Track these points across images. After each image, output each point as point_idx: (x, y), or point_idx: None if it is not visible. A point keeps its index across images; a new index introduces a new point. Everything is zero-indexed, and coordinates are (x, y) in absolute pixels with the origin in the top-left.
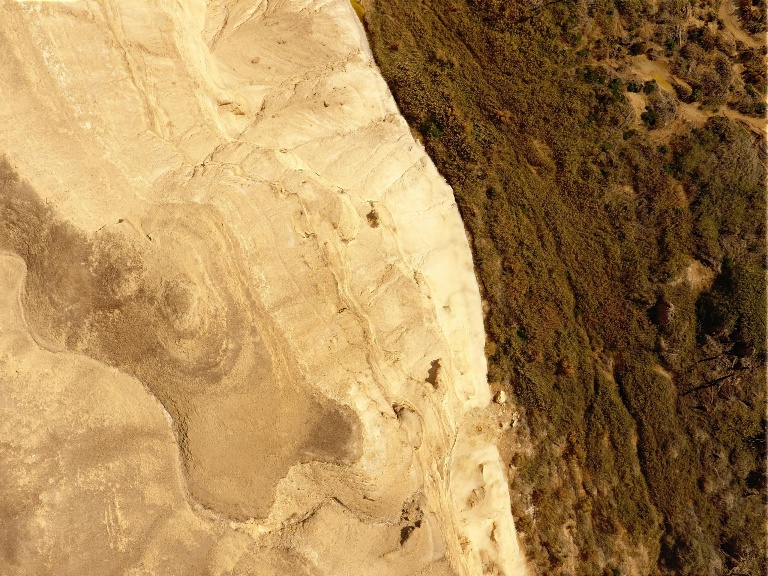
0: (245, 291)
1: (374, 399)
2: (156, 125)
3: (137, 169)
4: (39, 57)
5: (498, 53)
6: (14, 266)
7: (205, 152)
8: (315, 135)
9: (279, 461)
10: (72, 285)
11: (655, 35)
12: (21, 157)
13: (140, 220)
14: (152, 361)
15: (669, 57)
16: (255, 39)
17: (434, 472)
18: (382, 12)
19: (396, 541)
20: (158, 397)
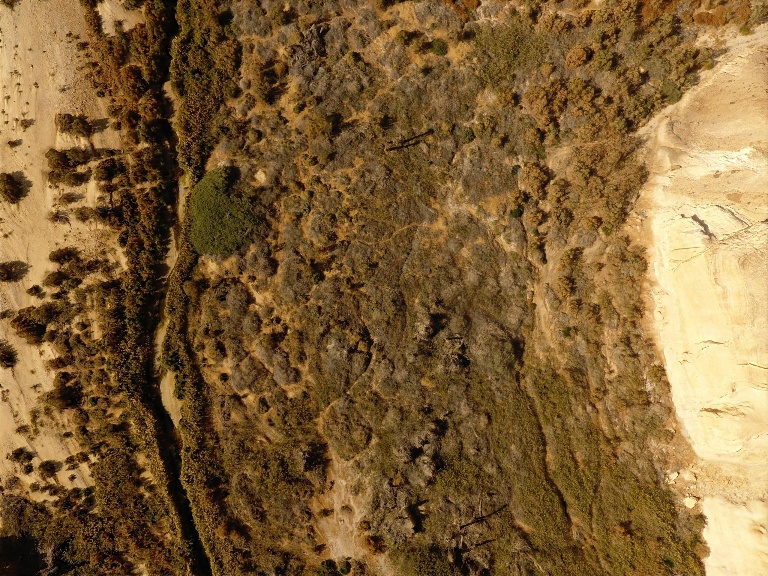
0: None
1: None
2: None
3: None
4: None
5: None
6: None
7: None
8: None
9: None
10: None
11: None
12: None
13: None
14: None
15: None
16: None
17: None
18: None
19: None
20: None
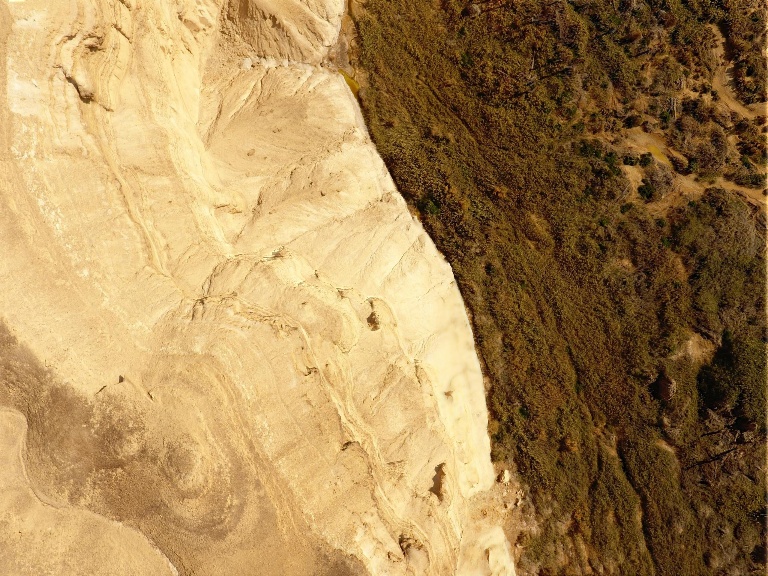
0: (248, 444)
1: (380, 540)
2: (154, 256)
3: (136, 314)
4: (34, 206)
5: (493, 128)
6: (14, 422)
7: (203, 275)
8: (313, 225)
9: None
10: (74, 446)
11: (650, 108)
12: (19, 318)
13: (141, 375)
14: (156, 518)
15: (664, 129)
16: (250, 131)
17: None
18: (376, 88)
19: None
20: (163, 551)
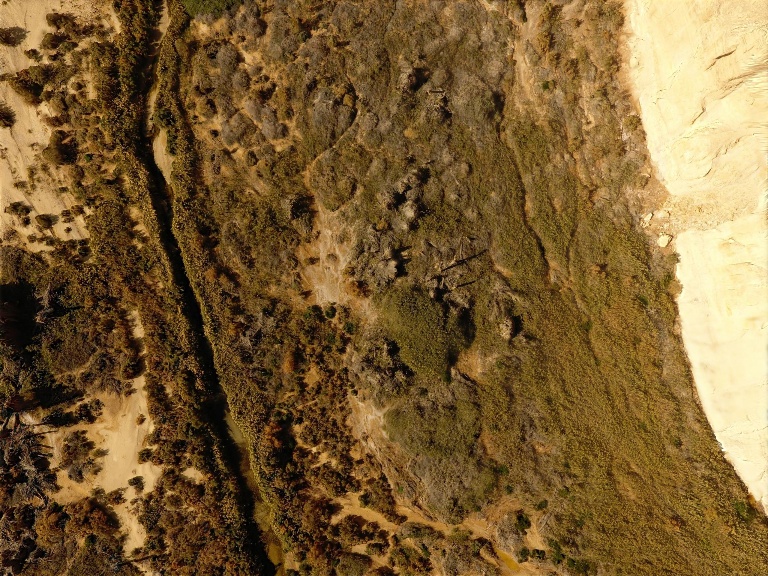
0: None
1: None
2: None
3: None
4: None
5: None
6: None
7: None
8: None
9: None
10: None
11: None
12: None
13: None
14: None
15: None
16: None
17: None
18: None
19: None
20: None
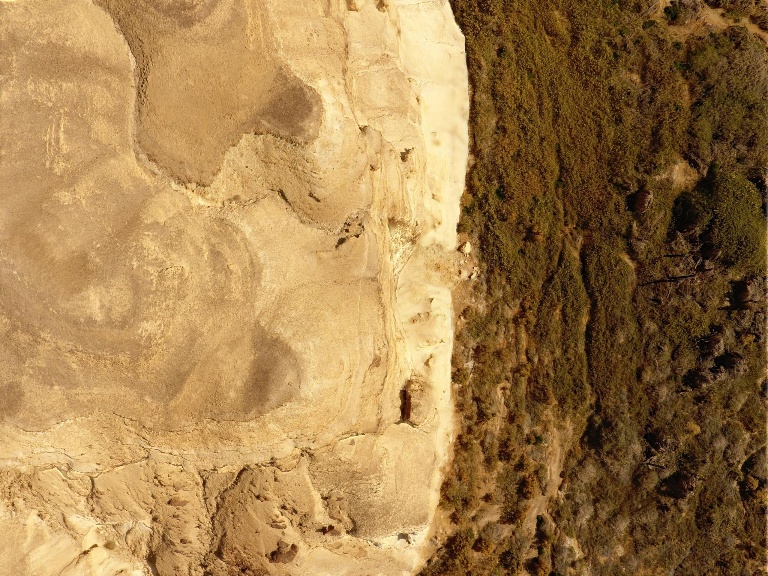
0: None
1: (341, 103)
2: None
3: None
4: None
5: None
6: None
7: None
8: None
9: (233, 125)
10: None
11: None
12: None
13: None
14: None
15: None
16: None
17: (384, 217)
18: None
19: (332, 245)
20: (126, 37)
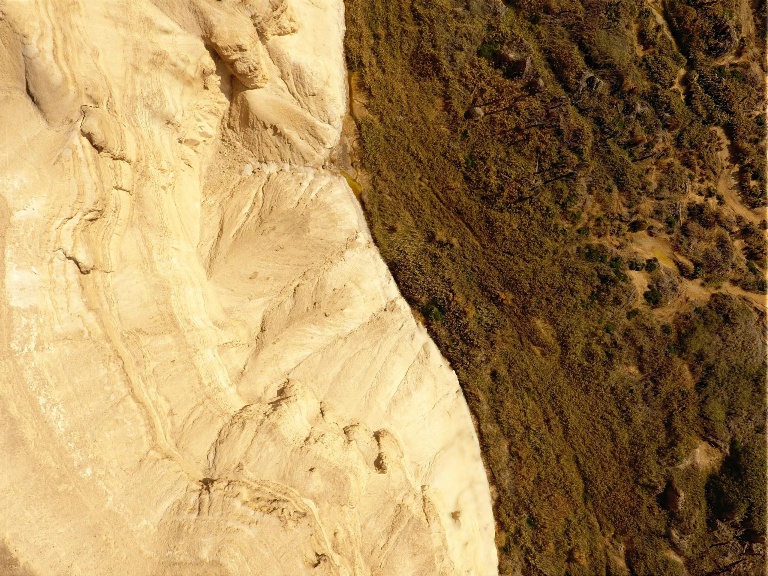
0: None
1: None
2: (158, 433)
3: (141, 511)
4: (35, 406)
5: (498, 233)
6: None
7: (208, 442)
8: (317, 346)
9: None
10: None
11: (655, 213)
12: (21, 536)
13: None
14: None
15: (670, 234)
16: (252, 253)
17: None
18: (379, 191)
19: None
20: None
